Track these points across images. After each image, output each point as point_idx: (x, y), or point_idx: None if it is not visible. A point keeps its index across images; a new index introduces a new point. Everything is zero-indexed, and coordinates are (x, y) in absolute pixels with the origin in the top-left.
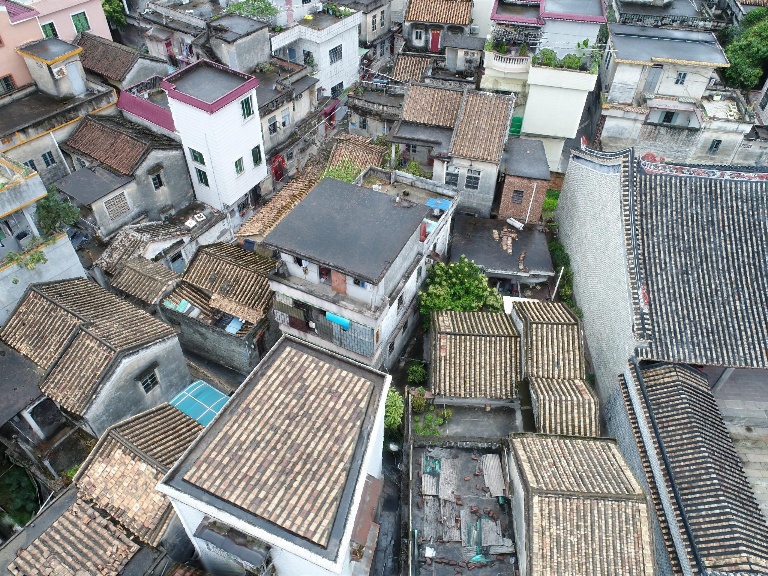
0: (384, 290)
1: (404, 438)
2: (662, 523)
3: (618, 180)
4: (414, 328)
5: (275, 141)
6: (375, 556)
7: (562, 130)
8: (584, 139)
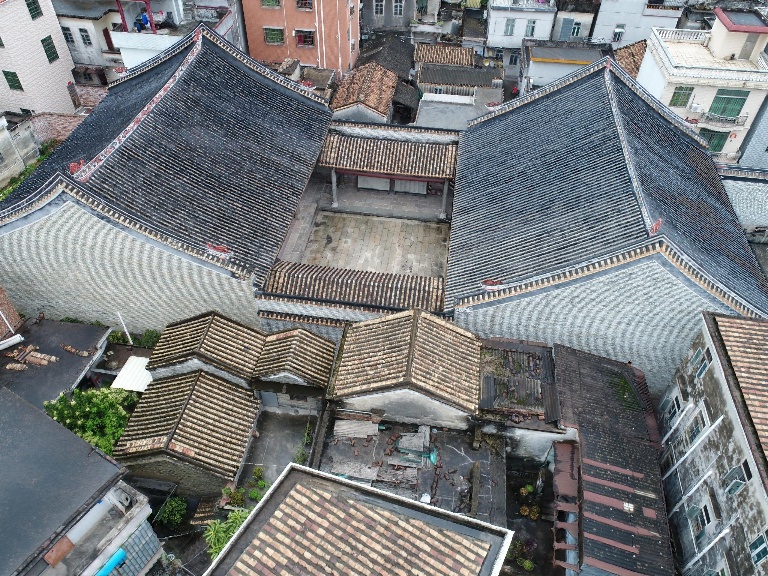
0: None
1: None
2: None
3: (74, 207)
4: None
5: None
6: None
7: None
8: None
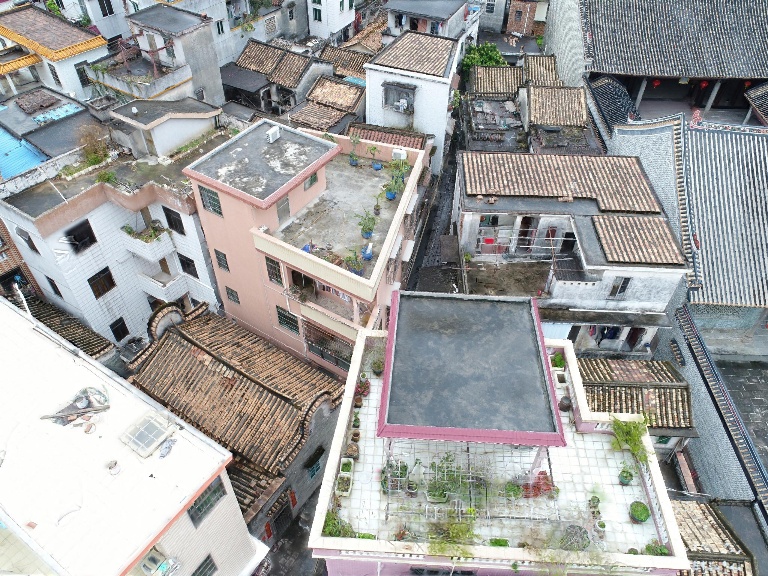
0: (448, 35)
1: (460, 116)
2: (597, 133)
3: None
4: None
5: (357, 1)
6: (446, 175)
7: None
8: None
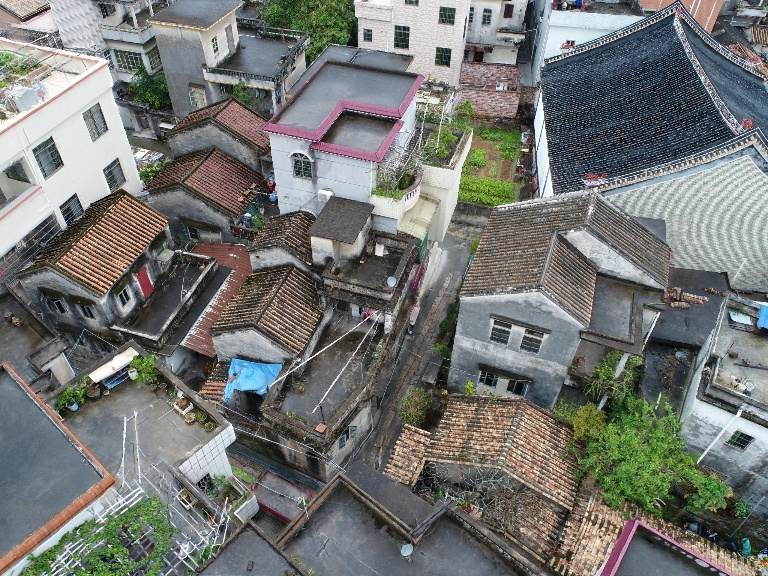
0: None
1: None
2: None
3: (747, 160)
4: None
5: None
6: None
7: None
8: (595, 176)
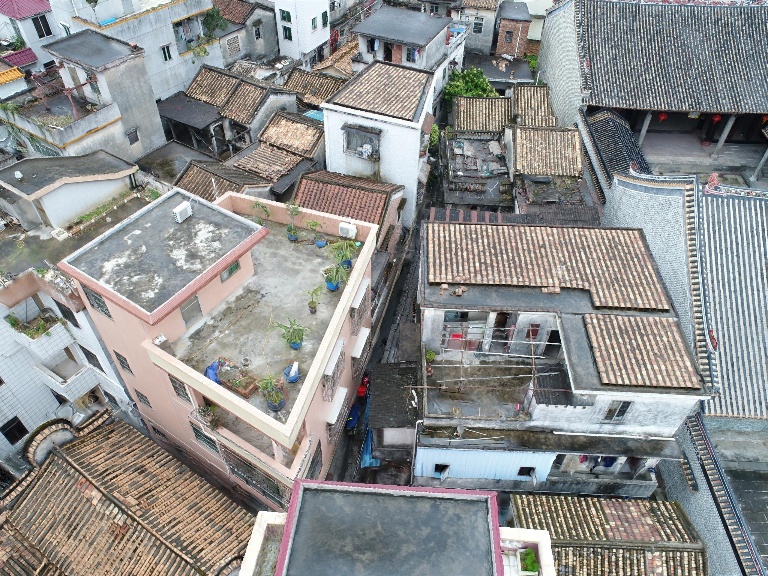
0: (426, 62)
1: (439, 155)
2: (594, 178)
3: (573, 5)
4: (439, 122)
5: (333, 17)
6: None
7: (541, 10)
8: None
